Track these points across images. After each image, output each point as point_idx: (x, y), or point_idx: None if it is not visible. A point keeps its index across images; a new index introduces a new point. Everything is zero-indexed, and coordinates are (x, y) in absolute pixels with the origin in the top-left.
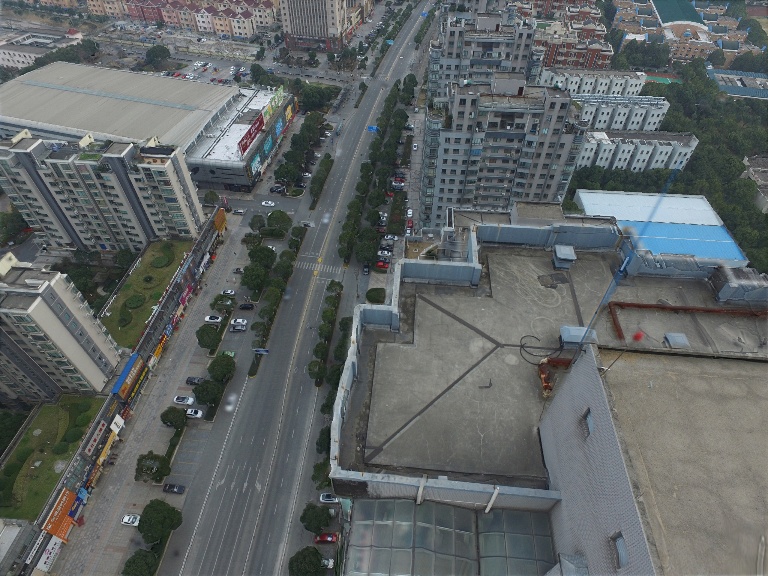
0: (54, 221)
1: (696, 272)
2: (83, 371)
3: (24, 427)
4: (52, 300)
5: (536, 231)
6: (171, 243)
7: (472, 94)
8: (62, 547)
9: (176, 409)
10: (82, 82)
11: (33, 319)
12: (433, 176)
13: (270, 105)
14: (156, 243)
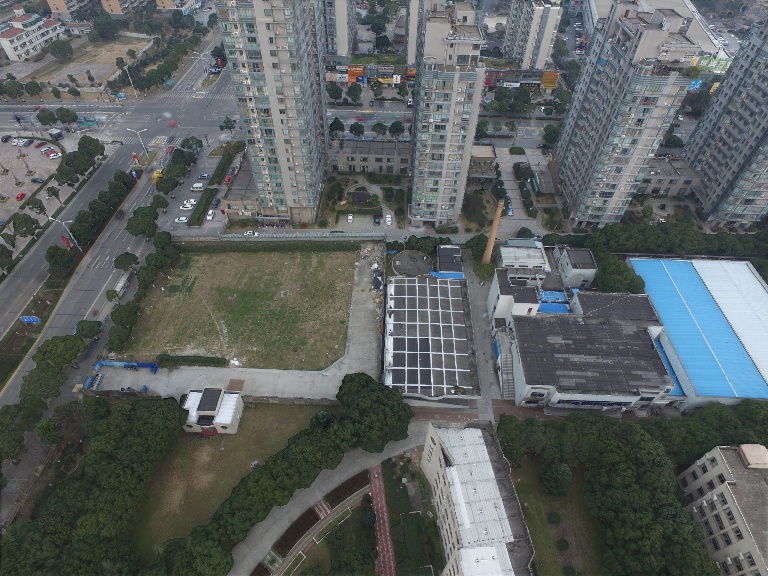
0: (508, 28)
1: None
2: (409, 46)
3: (388, 55)
4: None
5: None
6: None
7: (617, 2)
8: (347, 86)
9: (405, 86)
10: (656, 3)
11: (411, 0)
12: (582, 72)
13: (698, 60)
14: (512, 60)
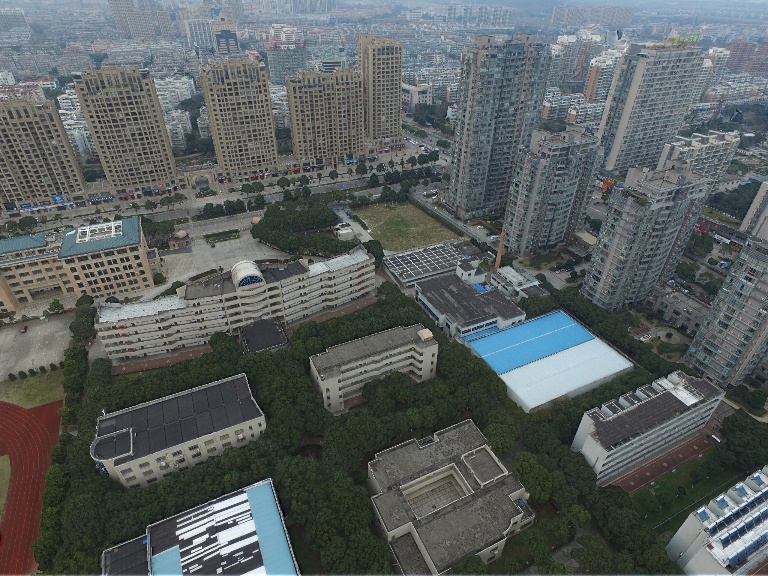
0: None
1: (530, 48)
2: None
3: None
4: (671, 150)
5: (544, 47)
6: (739, 223)
7: None
8: None
9: None
10: None
11: None
12: None
13: None
14: None
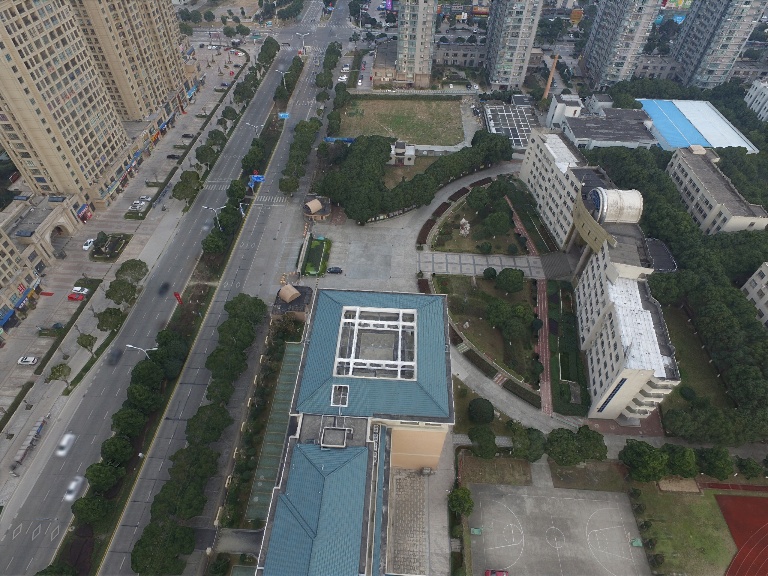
0: None
1: None
2: None
3: None
4: None
5: None
6: None
7: None
8: None
9: None
10: None
11: None
12: None
13: (684, 0)
14: None
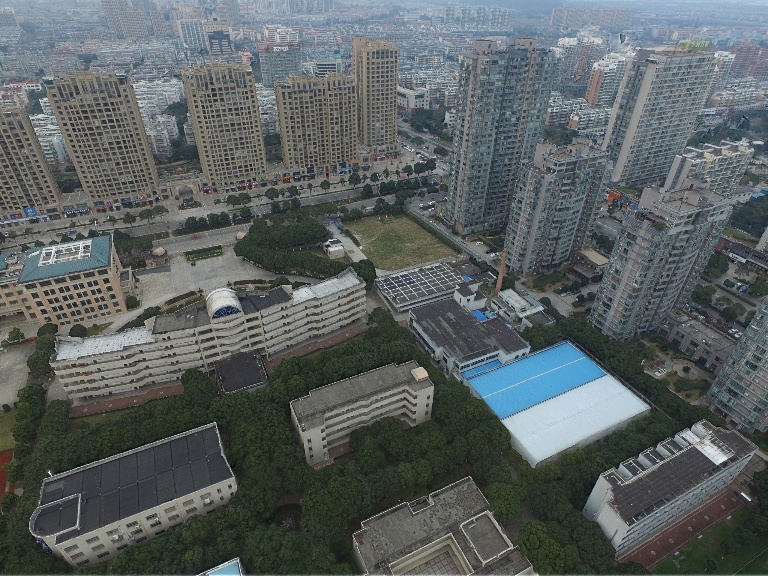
0: None
1: None
2: None
3: None
4: (682, 162)
5: None
6: (756, 241)
7: None
8: None
9: None
10: None
11: None
12: None
13: None
14: None
